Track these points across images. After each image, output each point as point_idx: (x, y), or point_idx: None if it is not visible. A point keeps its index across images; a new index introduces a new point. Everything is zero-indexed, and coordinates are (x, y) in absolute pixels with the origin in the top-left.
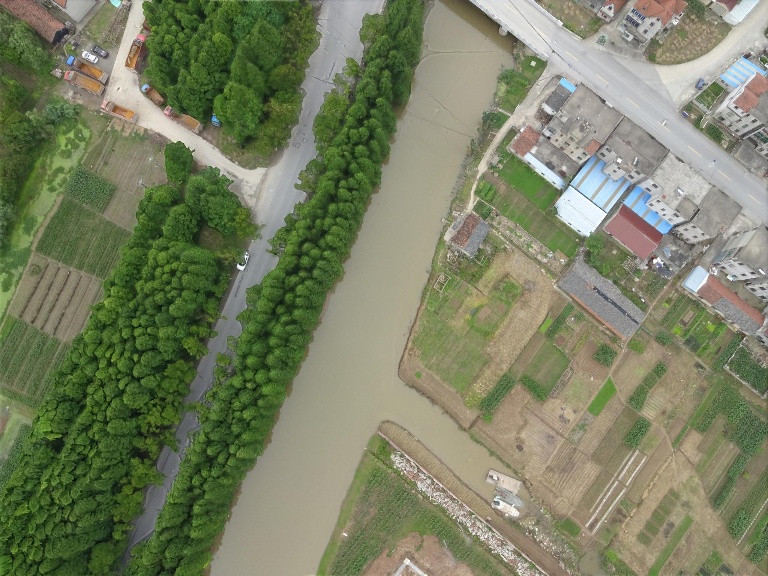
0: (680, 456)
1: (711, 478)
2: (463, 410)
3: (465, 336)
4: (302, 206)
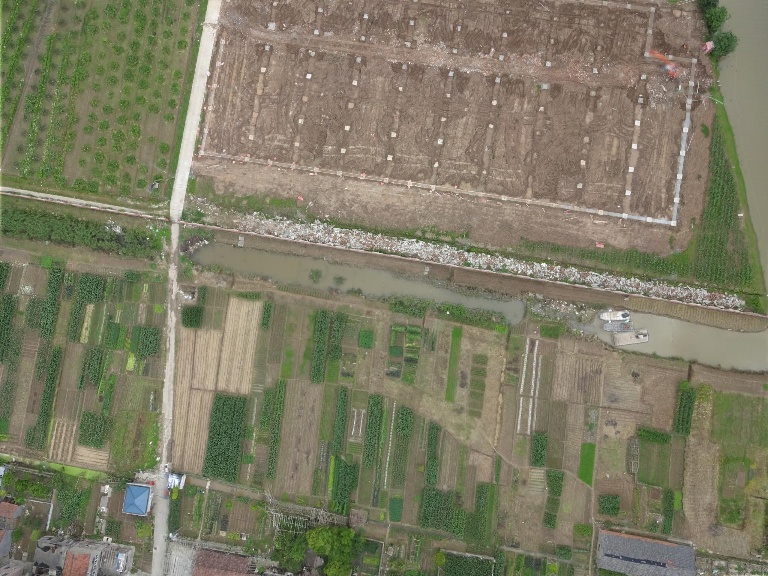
0: (488, 451)
1: (449, 447)
2: (708, 379)
3: (745, 447)
4: None
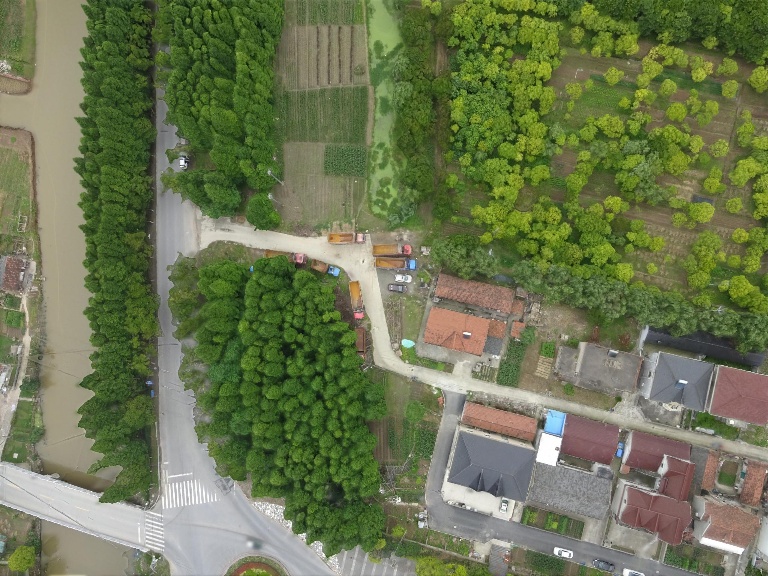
0: None
1: None
2: None
3: None
4: (126, 217)
